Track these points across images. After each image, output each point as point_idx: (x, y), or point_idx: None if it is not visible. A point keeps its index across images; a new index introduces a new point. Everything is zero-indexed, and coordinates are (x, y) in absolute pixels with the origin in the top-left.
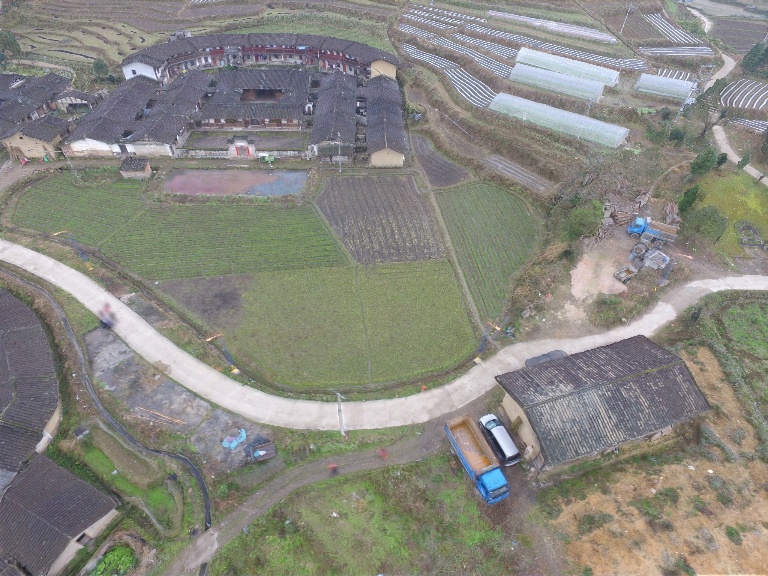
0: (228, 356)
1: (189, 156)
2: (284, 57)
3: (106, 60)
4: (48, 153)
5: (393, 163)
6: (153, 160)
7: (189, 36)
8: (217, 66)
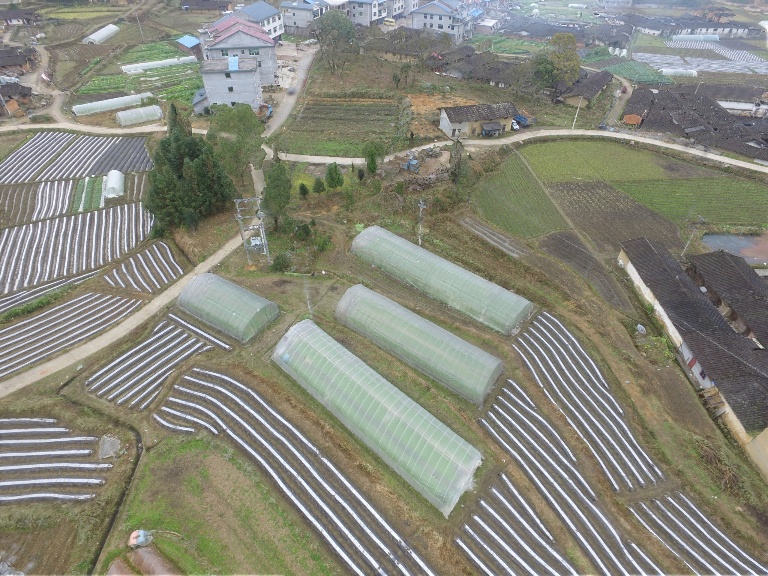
0: (642, 148)
1: None
2: None
3: None
4: None
5: None
6: None
7: None
8: None
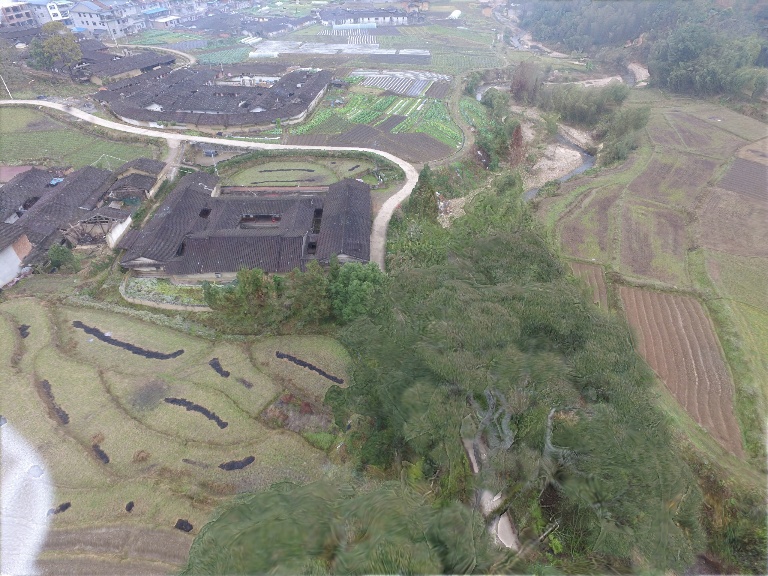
0: (42, 111)
1: None
2: None
3: (59, 320)
4: None
5: None
6: None
7: None
8: None
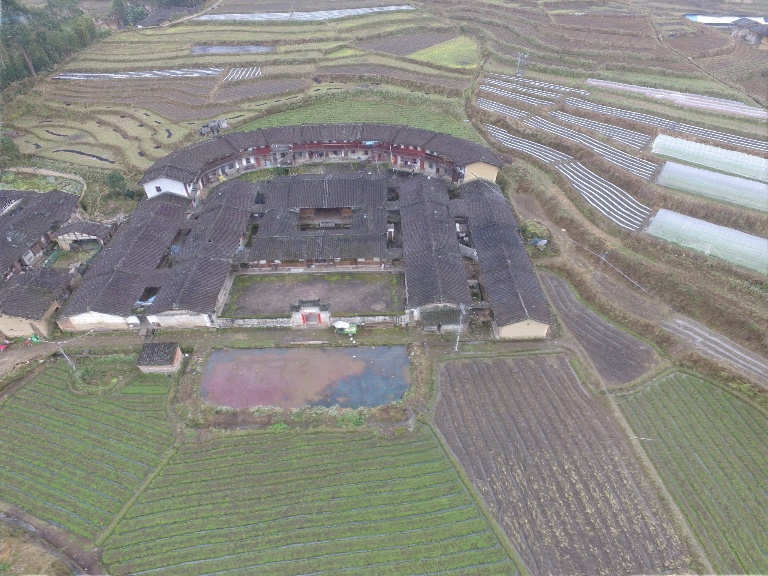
0: None
1: (235, 325)
2: (345, 153)
3: (124, 163)
4: (37, 332)
5: (532, 334)
6: (184, 334)
7: (225, 126)
8: (261, 167)
